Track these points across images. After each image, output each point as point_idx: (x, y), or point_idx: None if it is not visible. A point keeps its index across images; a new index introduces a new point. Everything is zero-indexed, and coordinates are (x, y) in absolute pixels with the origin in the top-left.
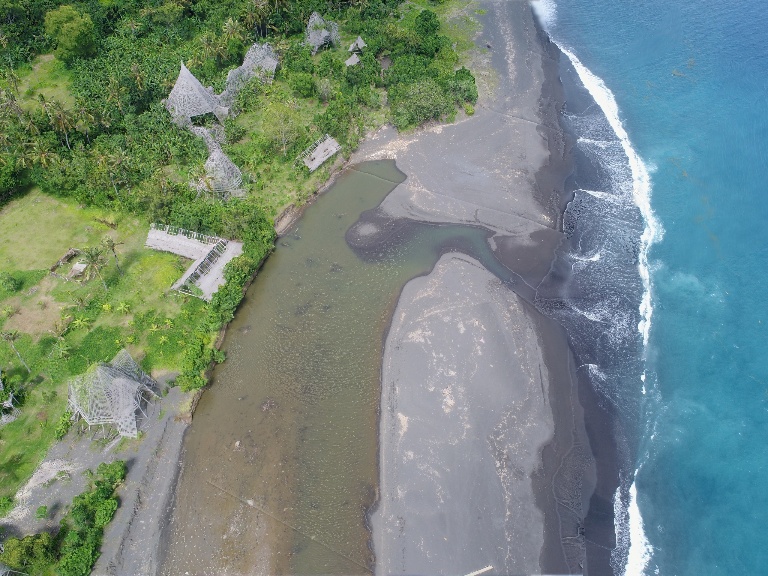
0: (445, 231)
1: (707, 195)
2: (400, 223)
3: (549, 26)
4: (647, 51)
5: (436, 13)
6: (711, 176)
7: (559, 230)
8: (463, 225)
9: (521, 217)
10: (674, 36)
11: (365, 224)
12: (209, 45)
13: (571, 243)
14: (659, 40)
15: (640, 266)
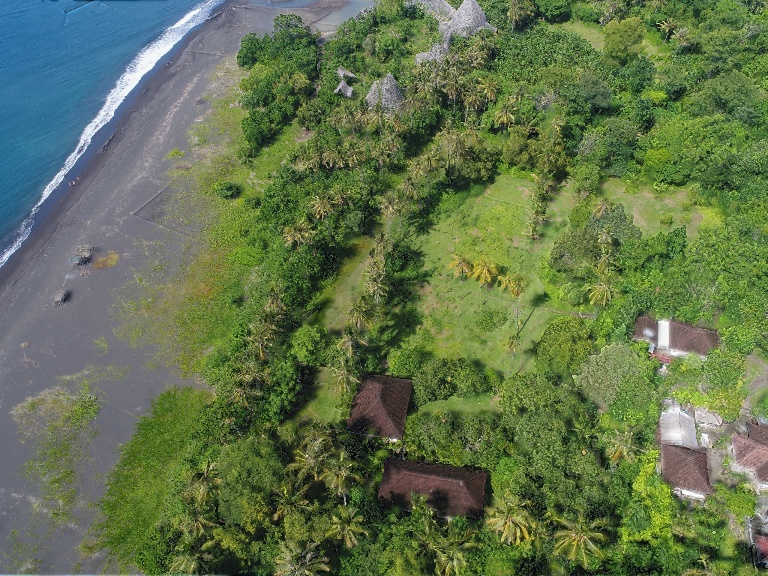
0: (293, 6)
1: (136, 2)
2: (318, 7)
3: (91, 159)
4: (35, 96)
5: (235, 167)
6: (126, 1)
7: (229, 6)
8: (282, 7)
9: (248, 7)
10: (4, 81)
11: (338, 6)
12: (481, 41)
13: (227, 3)
14: (13, 95)
15: (196, 1)
